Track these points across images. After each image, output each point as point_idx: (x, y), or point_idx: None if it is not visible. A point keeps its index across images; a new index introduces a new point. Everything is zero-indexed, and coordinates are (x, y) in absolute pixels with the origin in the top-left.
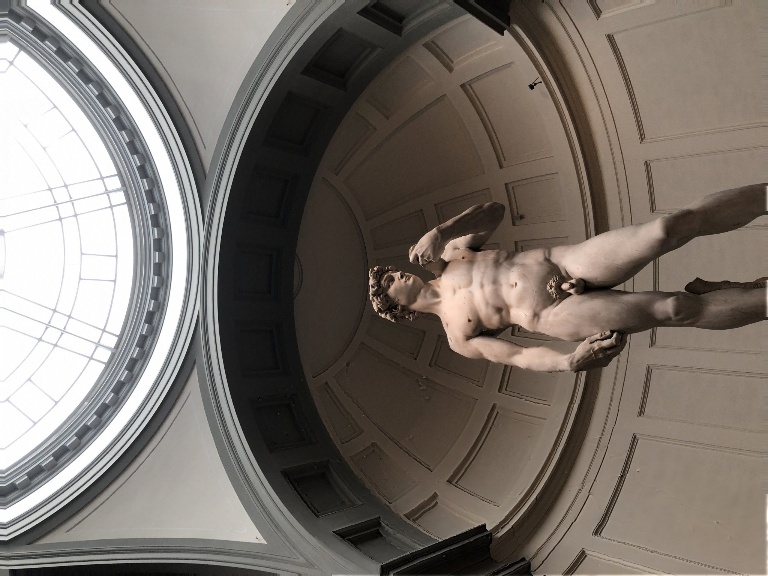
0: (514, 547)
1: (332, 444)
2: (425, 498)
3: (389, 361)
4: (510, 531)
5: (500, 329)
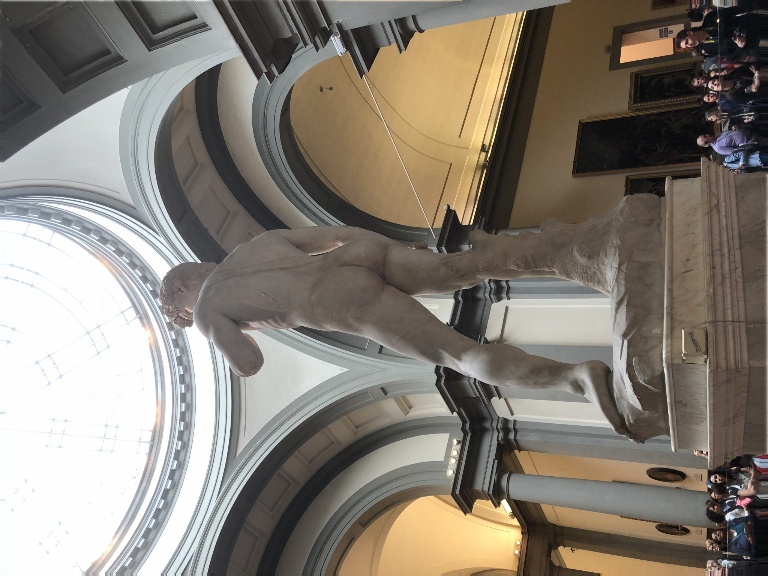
0: None
1: None
2: None
3: None
4: None
5: None
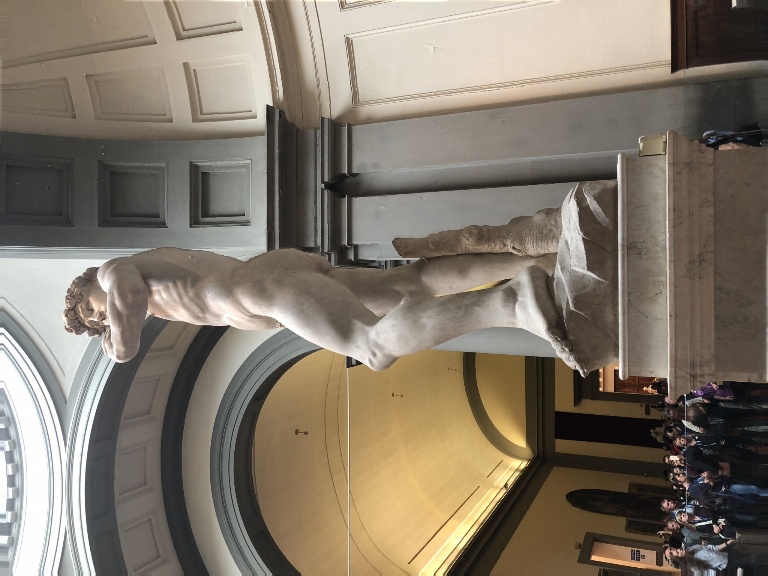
0: (297, 86)
1: (77, 140)
2: (182, 77)
3: None
4: (283, 76)
5: None
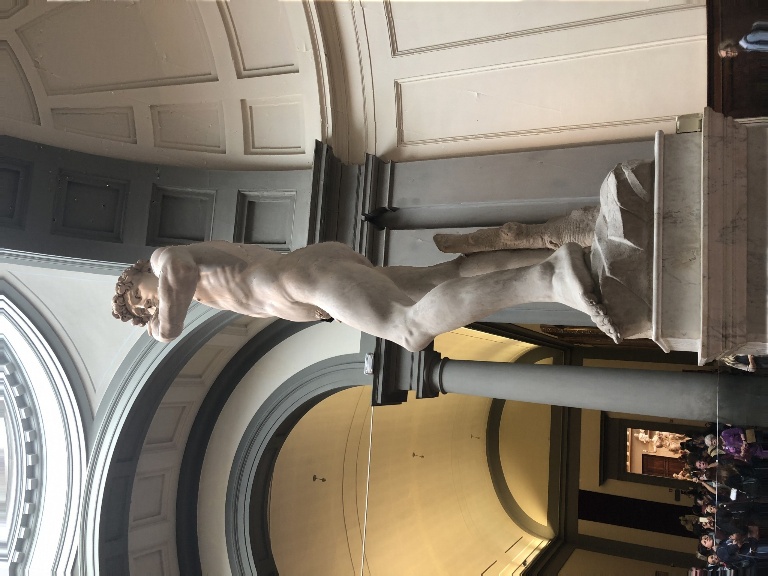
0: (346, 125)
1: (136, 164)
2: (239, 112)
3: (57, 10)
4: (333, 114)
5: None
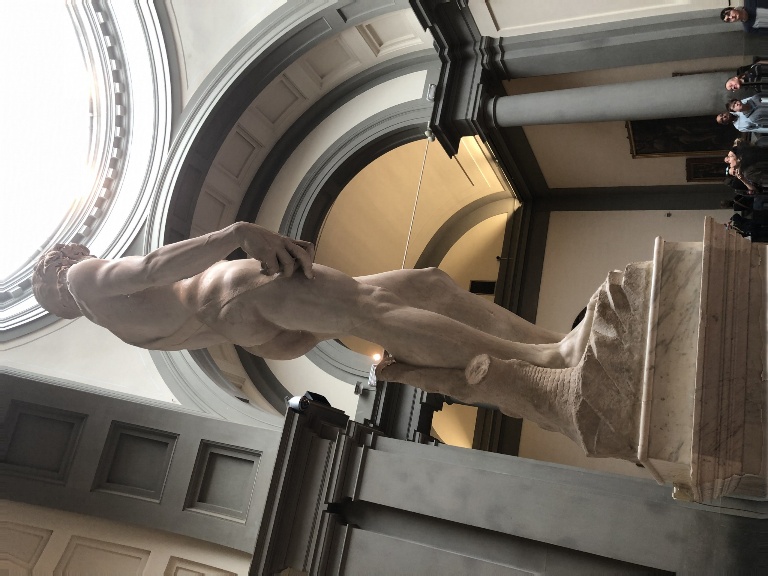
0: None
1: None
2: None
3: None
4: None
5: (149, 288)
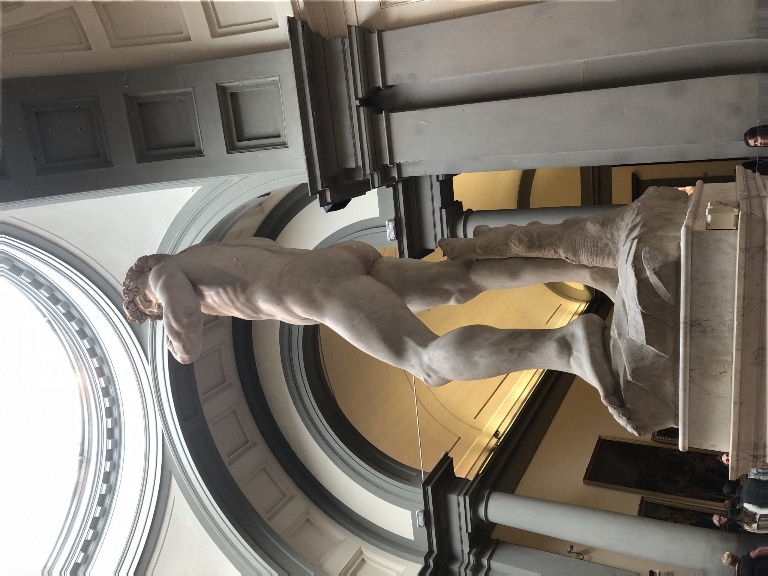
0: None
1: (98, 75)
2: None
3: None
4: None
5: None
